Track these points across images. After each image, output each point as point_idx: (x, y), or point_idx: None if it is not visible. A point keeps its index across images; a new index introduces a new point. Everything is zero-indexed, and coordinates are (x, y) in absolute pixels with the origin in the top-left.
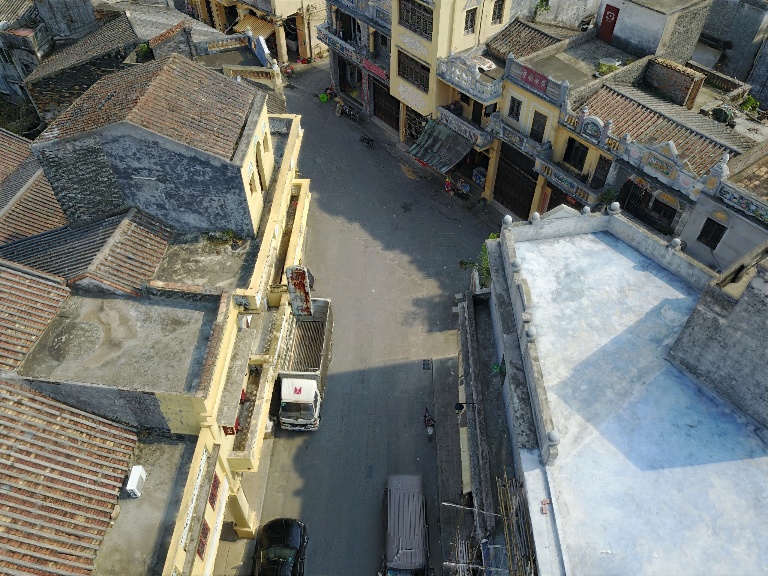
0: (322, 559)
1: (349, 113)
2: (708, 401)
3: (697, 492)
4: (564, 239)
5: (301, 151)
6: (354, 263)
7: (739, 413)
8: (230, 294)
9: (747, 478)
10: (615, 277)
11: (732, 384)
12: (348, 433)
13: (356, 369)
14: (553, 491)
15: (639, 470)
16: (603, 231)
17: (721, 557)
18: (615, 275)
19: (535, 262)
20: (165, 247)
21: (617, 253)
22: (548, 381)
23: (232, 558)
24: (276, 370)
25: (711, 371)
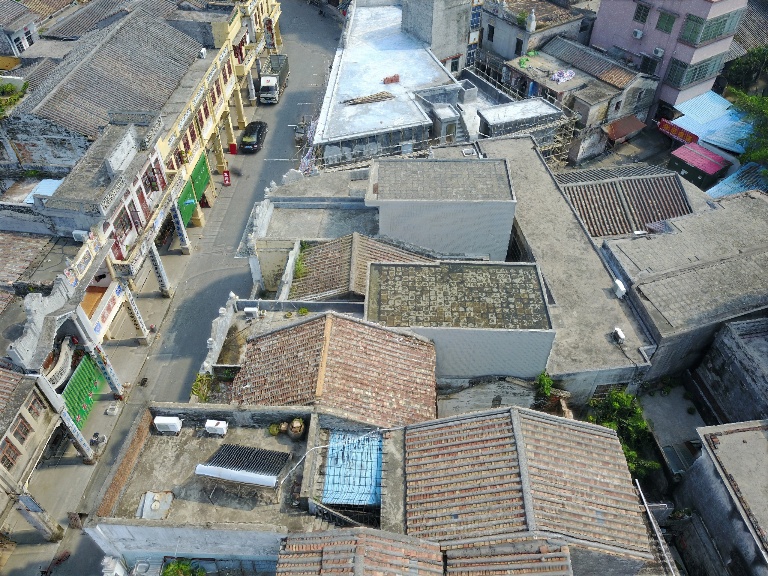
0: (273, 135)
1: (314, 1)
2: (410, 39)
3: (393, 54)
4: (380, 6)
5: (285, 18)
6: (305, 58)
7: (419, 41)
8: (239, 5)
9: (412, 52)
10: (395, 15)
11: (415, 29)
12: (291, 106)
13: (298, 89)
14: (344, 53)
15: (376, 50)
16: (398, 5)
17: (392, 63)
18: (396, 15)
19: (365, 11)
20: (214, 1)
21: (400, 10)
22: (354, 35)
23: (236, 134)
24: (257, 57)
25: (410, 27)
